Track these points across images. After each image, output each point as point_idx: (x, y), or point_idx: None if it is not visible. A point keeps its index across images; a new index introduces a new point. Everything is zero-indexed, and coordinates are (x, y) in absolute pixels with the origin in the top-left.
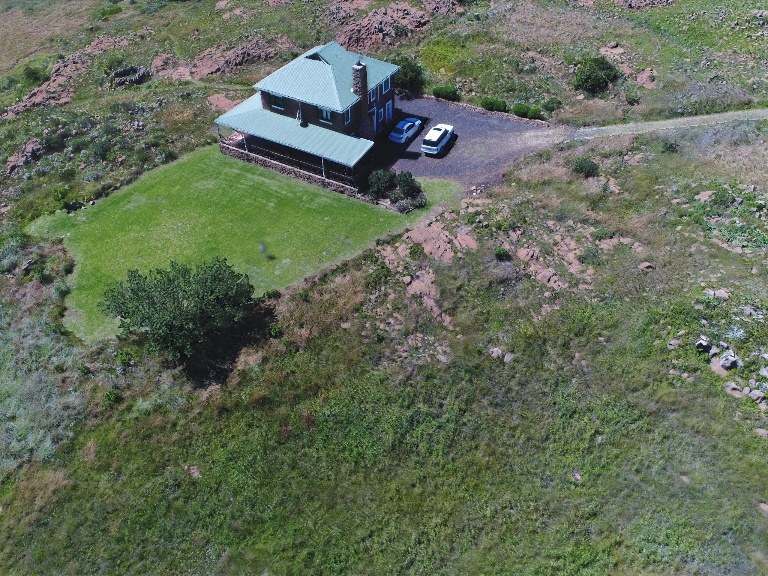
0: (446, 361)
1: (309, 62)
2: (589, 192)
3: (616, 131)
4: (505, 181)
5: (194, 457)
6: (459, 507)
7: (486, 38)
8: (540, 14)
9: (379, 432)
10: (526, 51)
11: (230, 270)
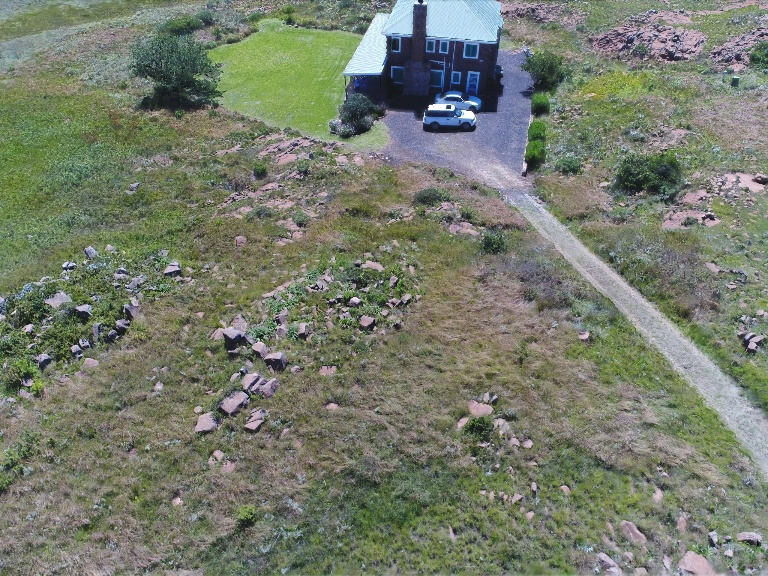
0: None
1: None
2: (379, 206)
3: (537, 218)
4: None
5: None
6: (3, 198)
7: None
8: None
9: None
10: (684, 128)
11: (194, 61)
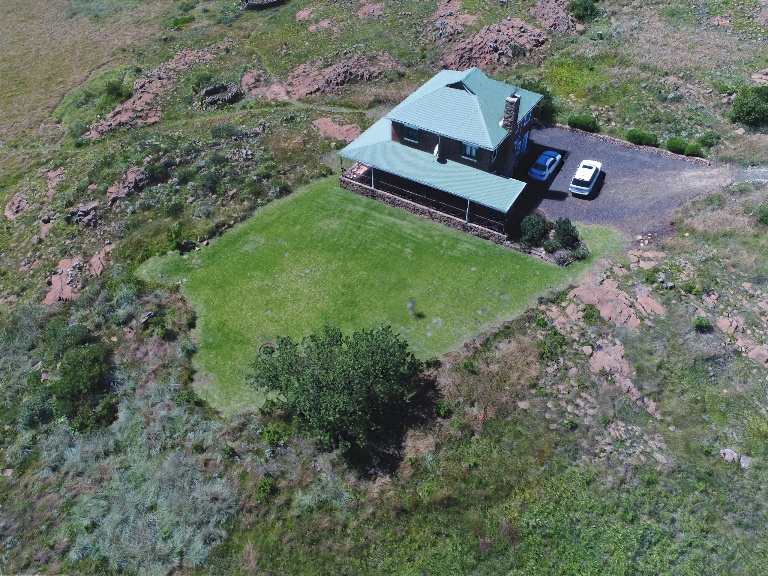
0: (666, 462)
1: (450, 91)
2: None
3: None
4: (675, 230)
5: (376, 572)
6: None
7: (615, 60)
8: (671, 34)
9: (602, 553)
10: (665, 76)
11: None
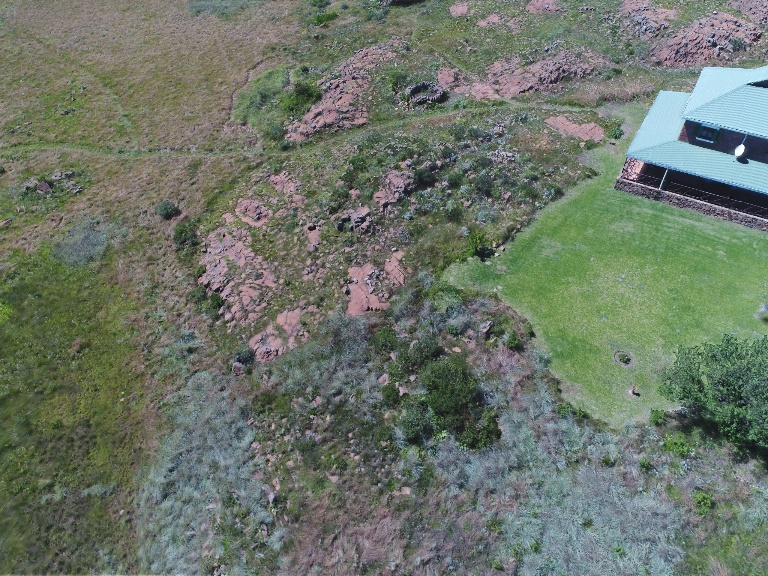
0: None
1: (754, 90)
2: None
3: None
4: None
5: None
6: None
7: None
8: None
9: None
10: None
11: None
